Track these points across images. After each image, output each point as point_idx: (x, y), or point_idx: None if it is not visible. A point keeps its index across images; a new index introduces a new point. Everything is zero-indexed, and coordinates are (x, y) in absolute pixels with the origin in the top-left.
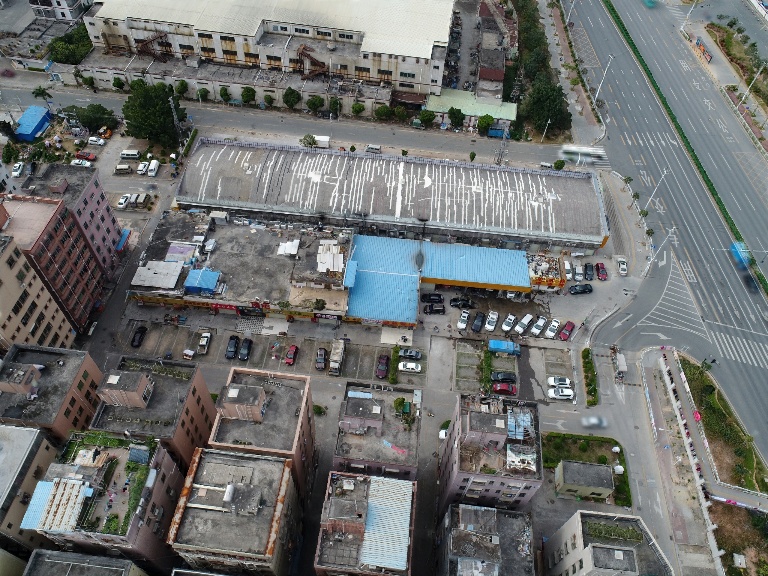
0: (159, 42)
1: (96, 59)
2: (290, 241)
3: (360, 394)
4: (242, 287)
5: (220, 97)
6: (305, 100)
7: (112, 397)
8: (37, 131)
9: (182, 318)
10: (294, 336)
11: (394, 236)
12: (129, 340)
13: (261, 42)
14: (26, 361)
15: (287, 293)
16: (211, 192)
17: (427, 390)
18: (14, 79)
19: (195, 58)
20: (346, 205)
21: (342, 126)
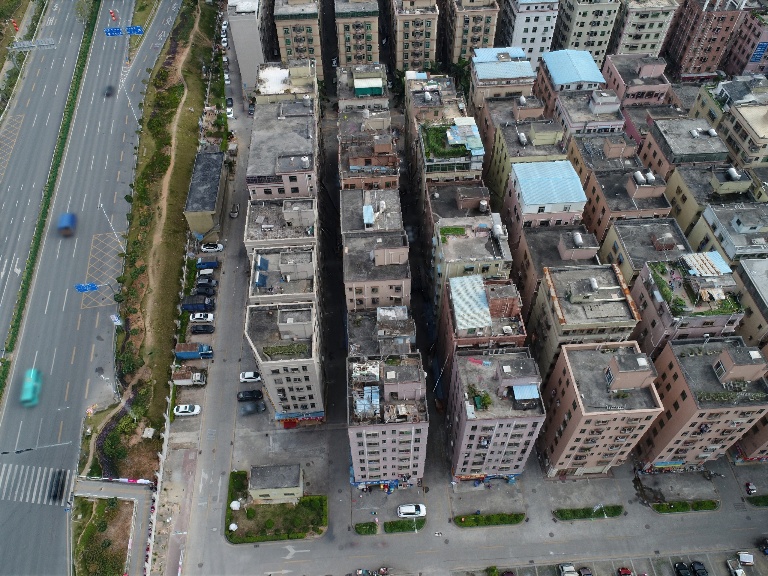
0: None
1: None
2: None
3: (527, 396)
4: None
5: None
6: None
7: None
8: None
9: None
10: None
11: None
12: None
13: None
14: None
15: None
16: None
17: (449, 568)
18: None
19: None
20: None
21: None
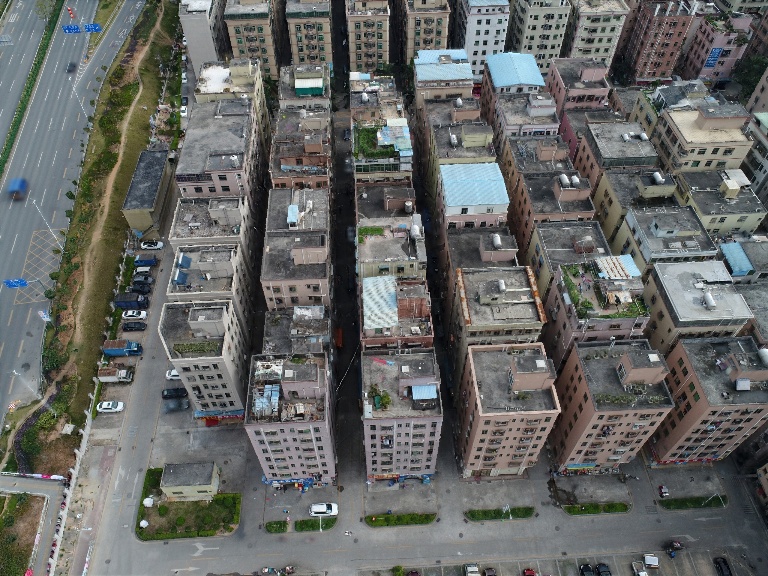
0: None
1: None
2: None
3: (425, 396)
4: None
5: None
6: None
7: None
8: None
9: None
10: None
11: None
12: (733, 569)
13: None
14: (759, 393)
15: None
16: None
17: (355, 567)
18: None
19: None
20: None
21: None
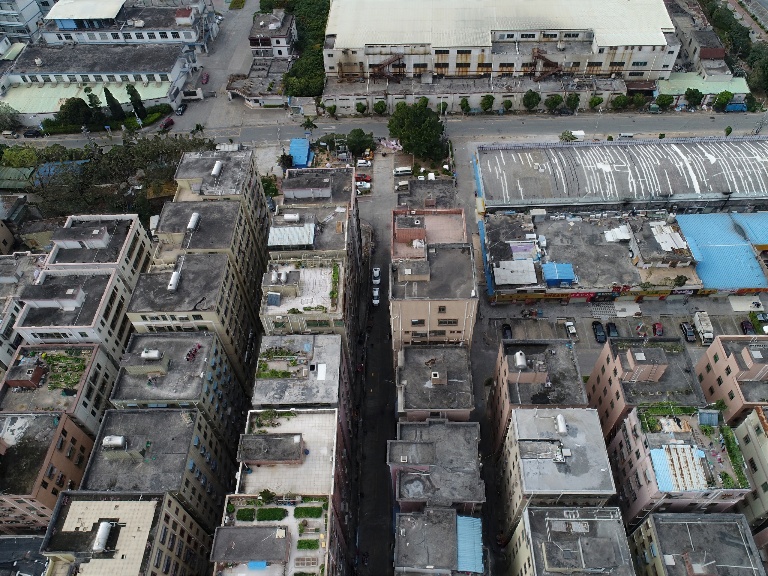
0: (394, 64)
1: (334, 88)
2: (612, 228)
3: None
4: (592, 275)
5: (457, 108)
6: (542, 100)
7: (636, 373)
8: (307, 161)
9: (539, 311)
10: (649, 315)
11: (691, 213)
12: (498, 338)
13: (492, 51)
14: None
15: (637, 275)
16: (514, 193)
17: None
18: (255, 117)
19: (429, 75)
20: (646, 189)
21: (581, 120)
